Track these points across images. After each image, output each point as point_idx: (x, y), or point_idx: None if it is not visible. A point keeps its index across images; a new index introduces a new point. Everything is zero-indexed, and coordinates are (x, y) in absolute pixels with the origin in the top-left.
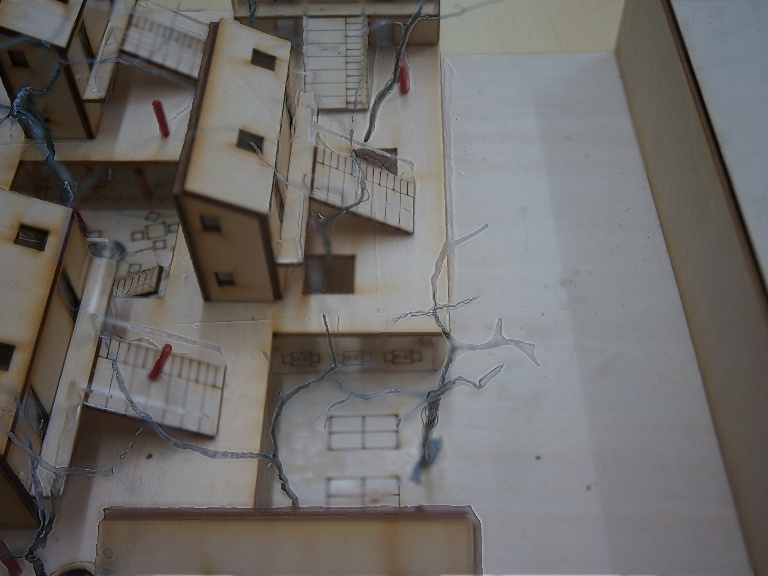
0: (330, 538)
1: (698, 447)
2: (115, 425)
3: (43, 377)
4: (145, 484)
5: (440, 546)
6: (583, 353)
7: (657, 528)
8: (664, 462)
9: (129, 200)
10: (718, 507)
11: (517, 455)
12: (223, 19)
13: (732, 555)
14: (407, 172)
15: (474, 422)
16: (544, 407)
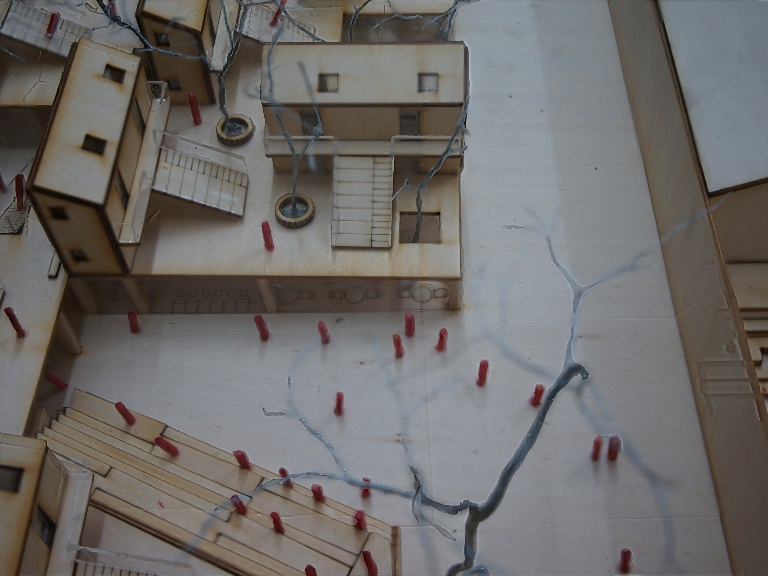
0: (387, 54)
1: (613, 91)
2: (251, 52)
3: (213, 9)
4: None
5: (446, 57)
6: (543, 43)
7: (583, 130)
8: (590, 98)
9: None
10: (622, 120)
11: (497, 95)
12: None
13: (628, 142)
14: None
15: (470, 79)
16: (516, 71)
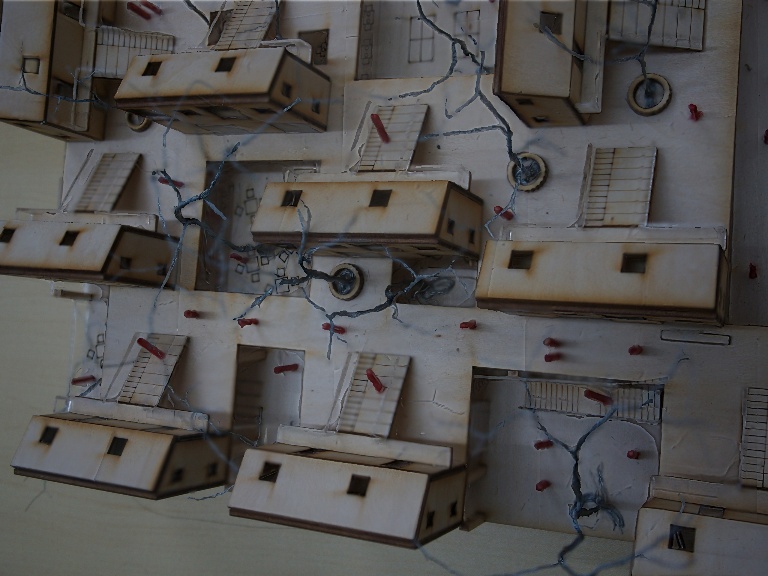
0: None
1: None
2: None
3: None
4: (457, 146)
5: None
6: None
7: None
8: None
9: (223, 231)
10: None
11: None
12: (115, 97)
13: None
14: (233, 0)
15: None
16: None
